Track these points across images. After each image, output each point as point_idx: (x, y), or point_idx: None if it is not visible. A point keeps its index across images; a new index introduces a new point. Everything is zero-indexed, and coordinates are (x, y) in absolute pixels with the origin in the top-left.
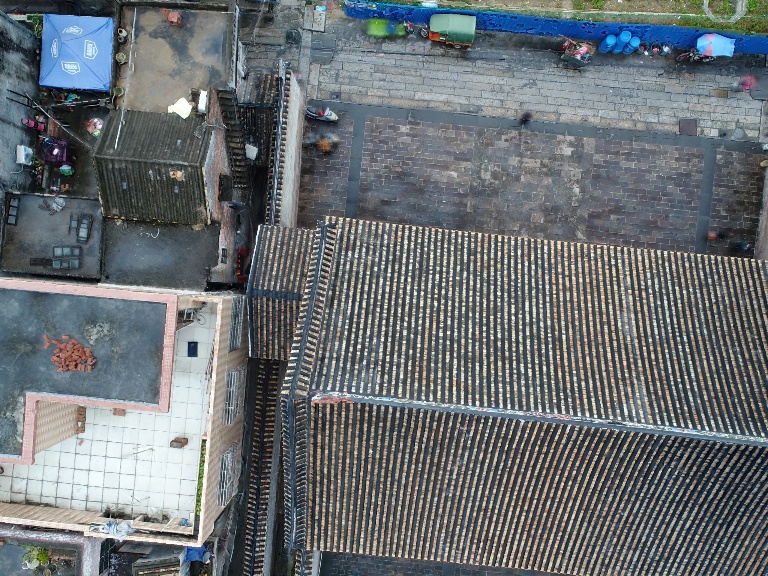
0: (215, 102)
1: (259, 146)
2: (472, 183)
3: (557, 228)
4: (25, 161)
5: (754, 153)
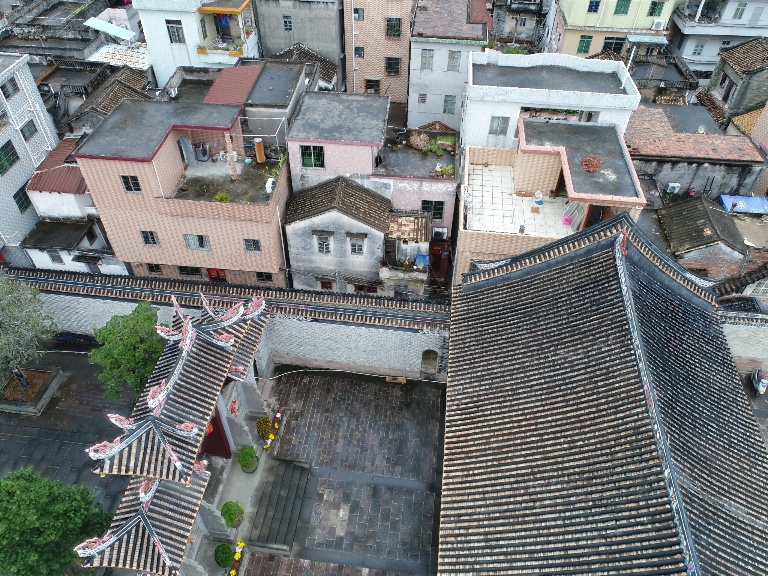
0: (763, 259)
1: None
2: None
3: None
4: (671, 187)
5: None
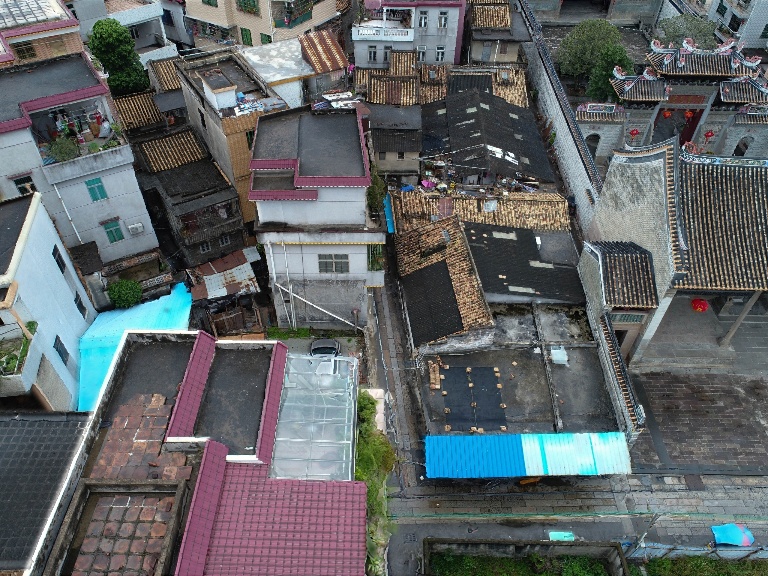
0: None
1: None
2: None
3: (762, 393)
4: None
5: None
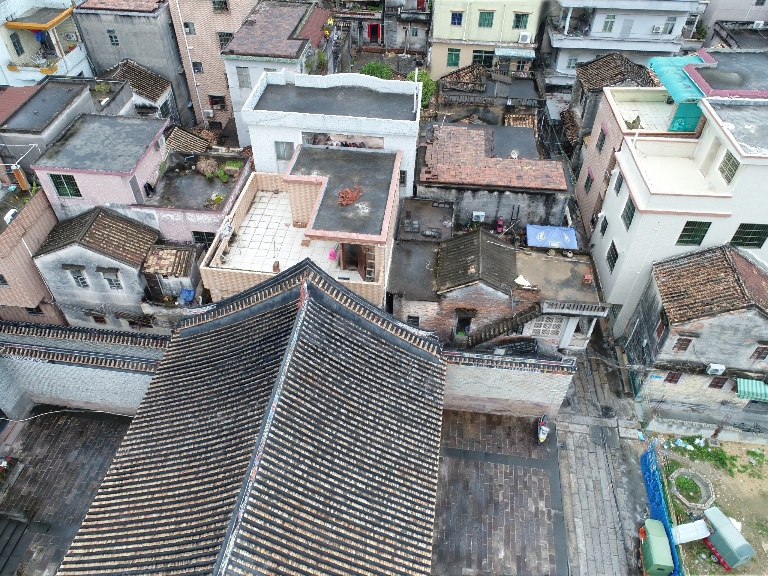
0: (530, 300)
1: None
2: (494, 575)
3: None
4: (475, 216)
5: None
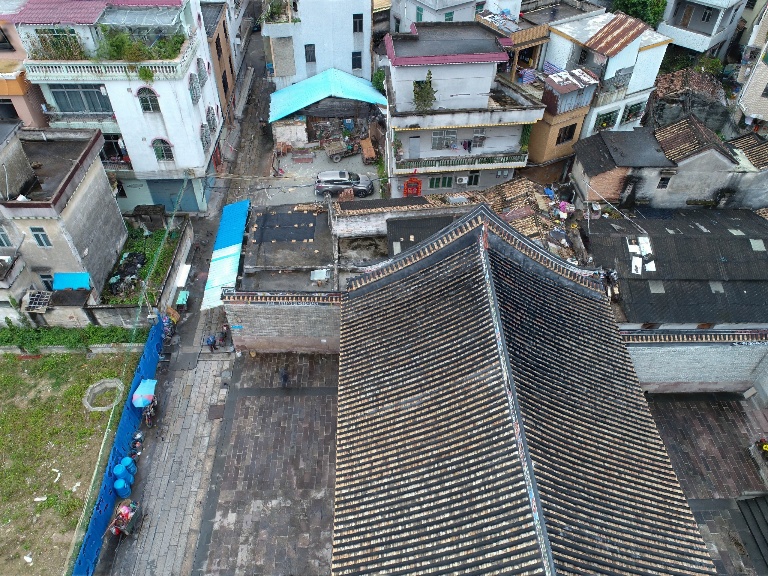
0: None
1: None
2: None
3: (314, 518)
4: None
5: (244, 362)
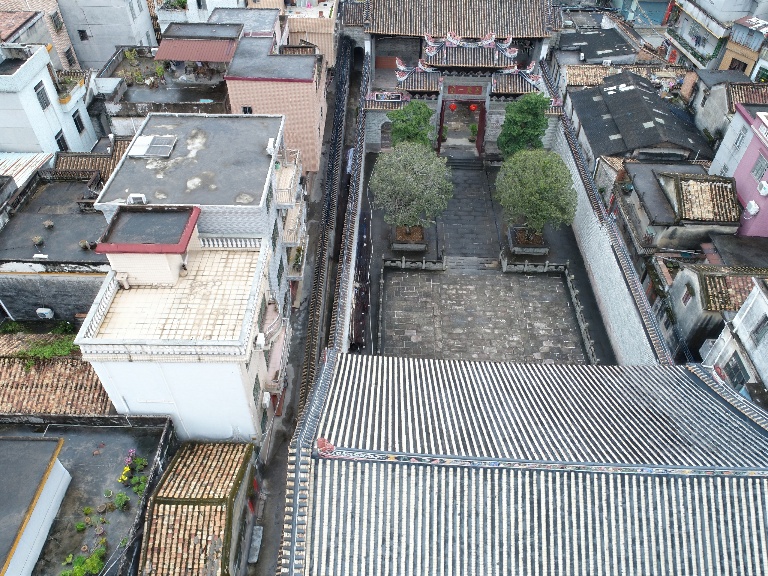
0: None
1: (340, 13)
2: None
3: None
4: None
5: None
